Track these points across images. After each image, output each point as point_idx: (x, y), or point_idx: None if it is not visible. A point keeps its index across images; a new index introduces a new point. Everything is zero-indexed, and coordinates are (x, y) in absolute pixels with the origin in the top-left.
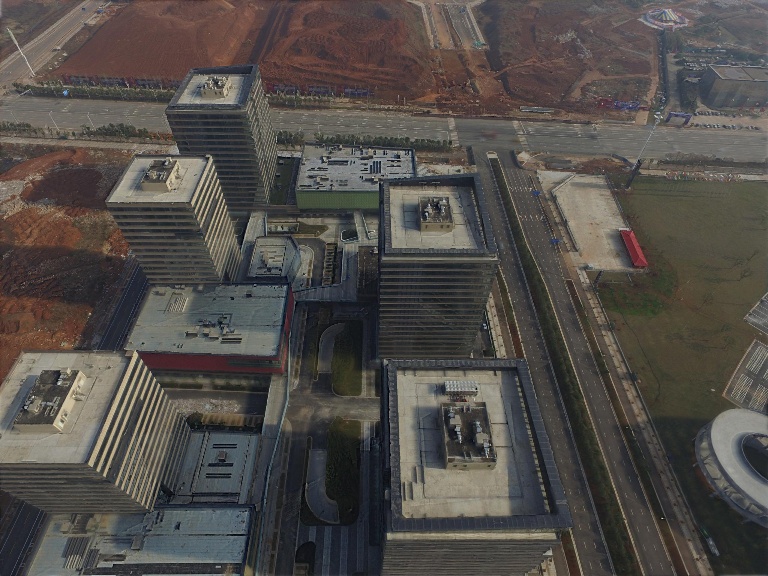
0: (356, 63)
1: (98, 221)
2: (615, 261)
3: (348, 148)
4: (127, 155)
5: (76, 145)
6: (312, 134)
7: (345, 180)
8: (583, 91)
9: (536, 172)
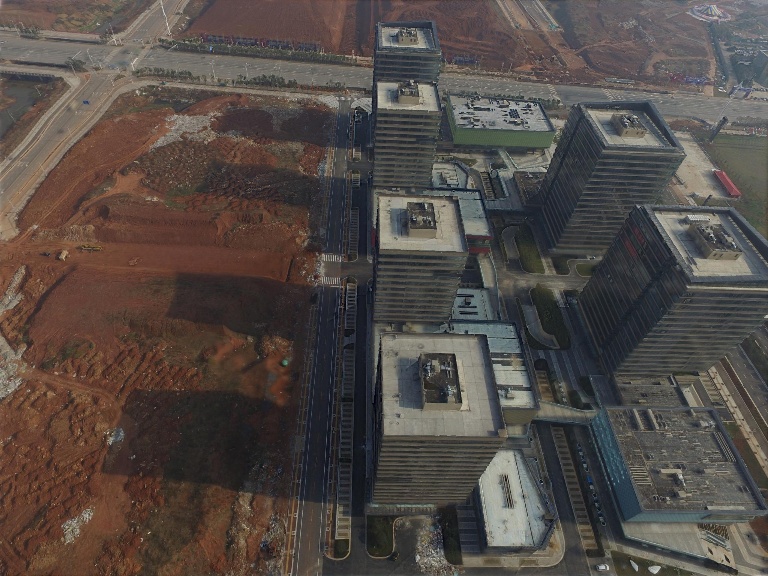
0: (458, 36)
1: (285, 149)
2: (714, 192)
3: (485, 99)
4: (284, 101)
5: (236, 91)
6: None
7: (493, 122)
8: (655, 68)
9: None
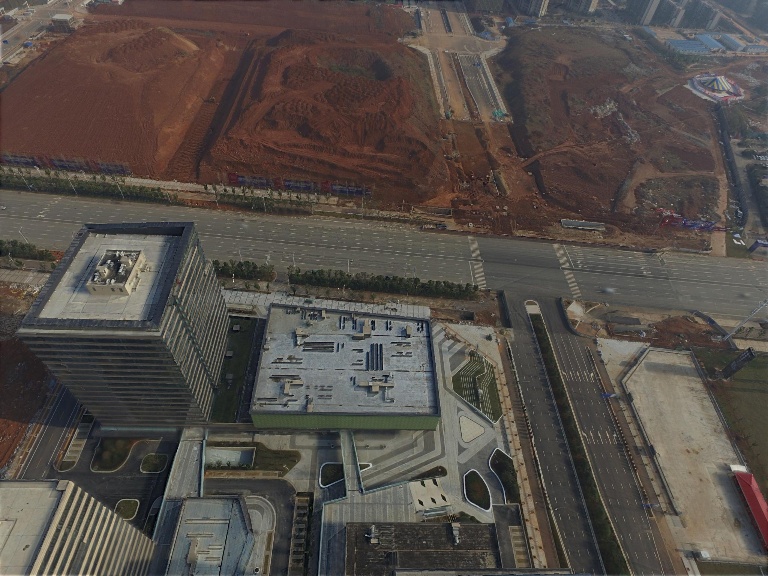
0: (348, 144)
1: None
2: (736, 538)
3: (334, 315)
4: (16, 294)
5: None
6: (285, 261)
7: (328, 386)
8: (638, 197)
9: (596, 342)
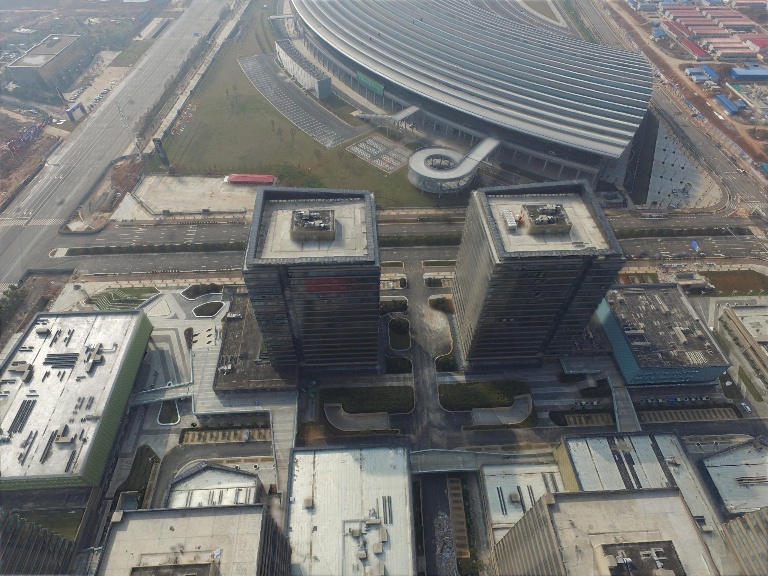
0: None
1: None
2: None
3: None
4: None
5: None
6: None
7: (78, 401)
8: None
9: (113, 220)
